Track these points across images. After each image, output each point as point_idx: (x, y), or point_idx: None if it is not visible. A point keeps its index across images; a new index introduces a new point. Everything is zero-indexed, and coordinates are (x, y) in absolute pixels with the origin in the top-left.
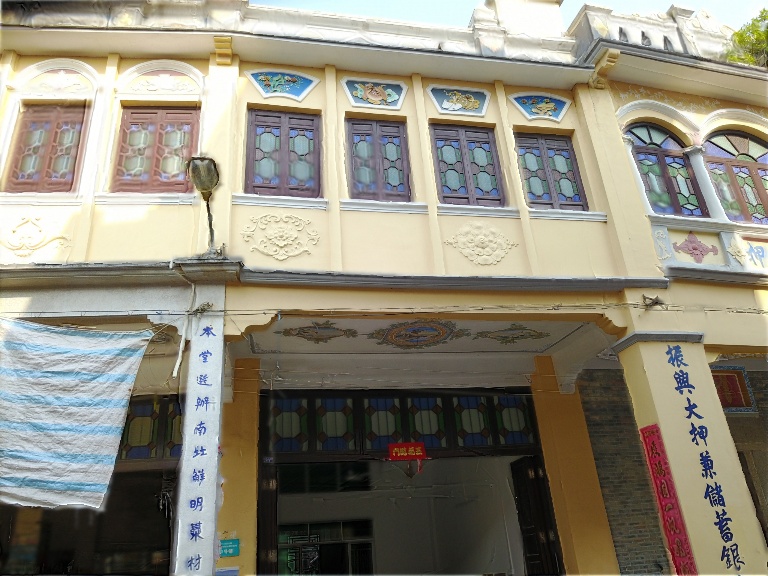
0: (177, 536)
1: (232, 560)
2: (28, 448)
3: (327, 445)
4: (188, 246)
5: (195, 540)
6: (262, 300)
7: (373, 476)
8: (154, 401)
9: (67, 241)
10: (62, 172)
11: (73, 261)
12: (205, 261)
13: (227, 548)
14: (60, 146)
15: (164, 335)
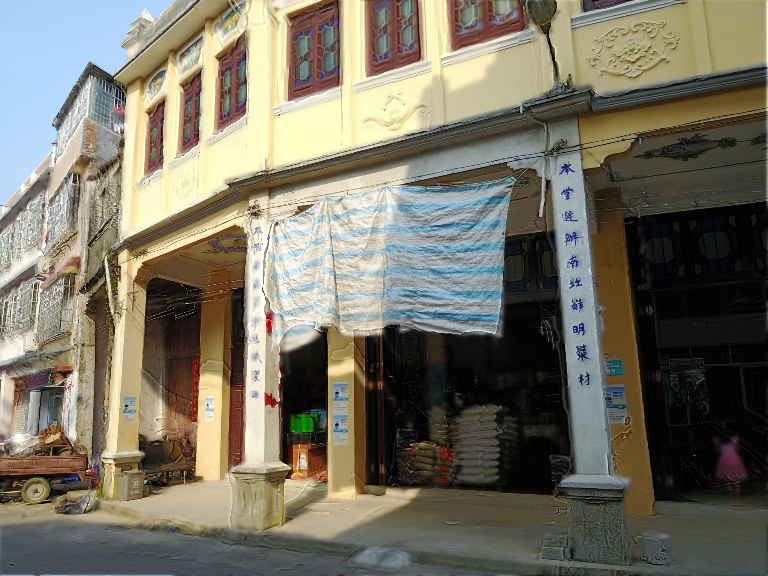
0: (565, 357)
1: (616, 378)
2: (433, 289)
3: (707, 268)
4: (534, 86)
5: (582, 360)
6: (619, 126)
7: (767, 297)
8: (521, 240)
9: (427, 108)
10: (410, 44)
11: (435, 125)
12: (554, 98)
13: (609, 368)
14: (403, 19)
15: (525, 179)
